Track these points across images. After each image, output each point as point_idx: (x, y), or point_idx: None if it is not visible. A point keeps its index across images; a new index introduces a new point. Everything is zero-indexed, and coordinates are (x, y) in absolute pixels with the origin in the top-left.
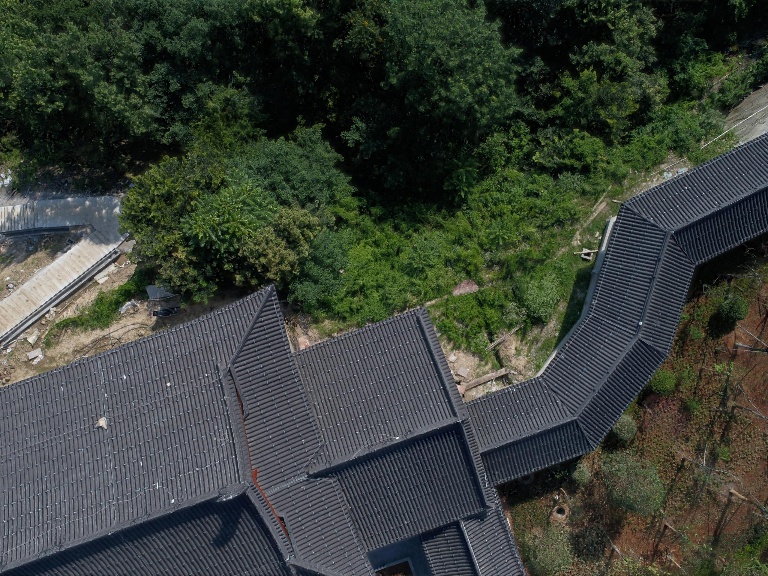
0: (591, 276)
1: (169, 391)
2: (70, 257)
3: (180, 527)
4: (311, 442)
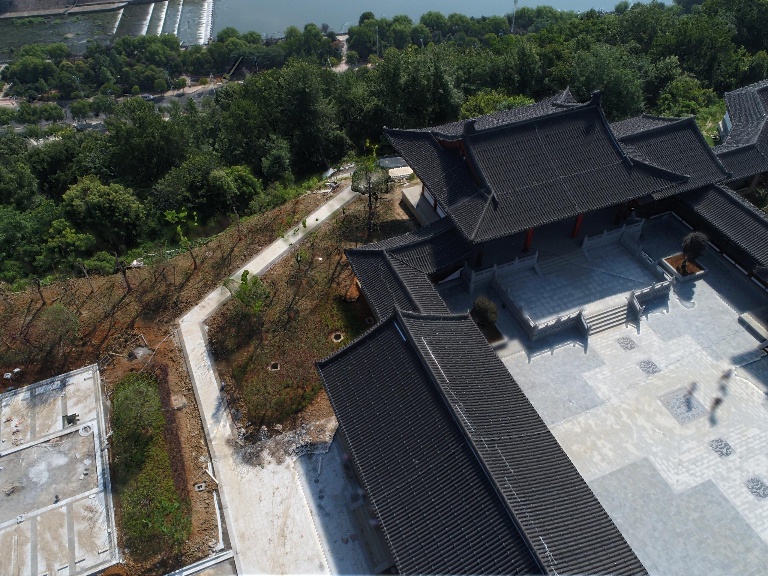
0: (722, 142)
1: None
2: (407, 168)
3: (564, 130)
4: None
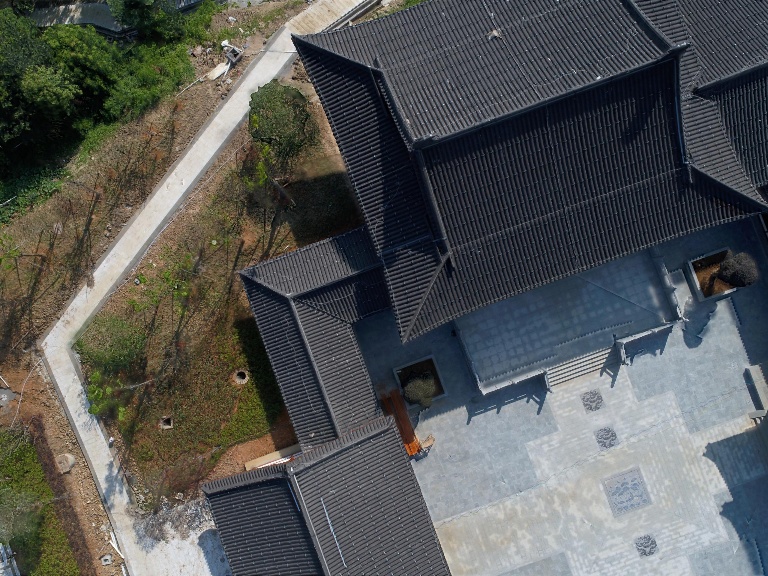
0: None
1: (559, 5)
2: None
3: (598, 112)
4: (691, 65)
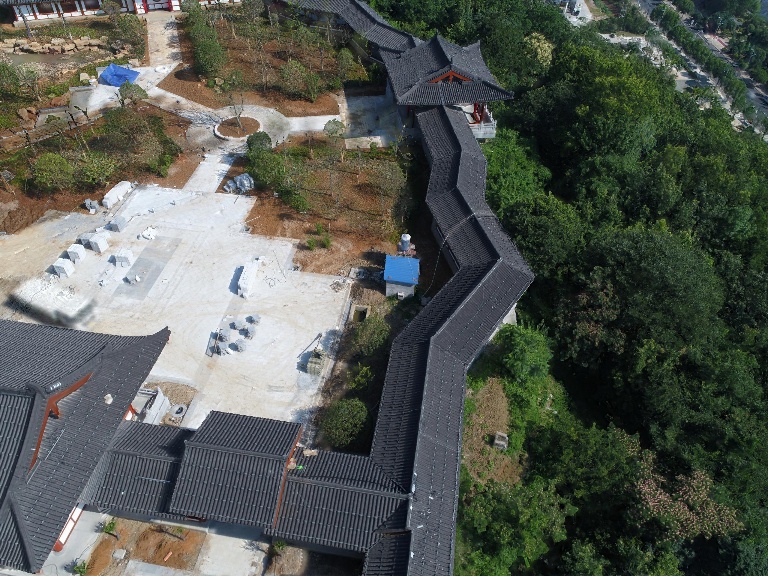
0: None
1: None
2: None
3: None
4: None
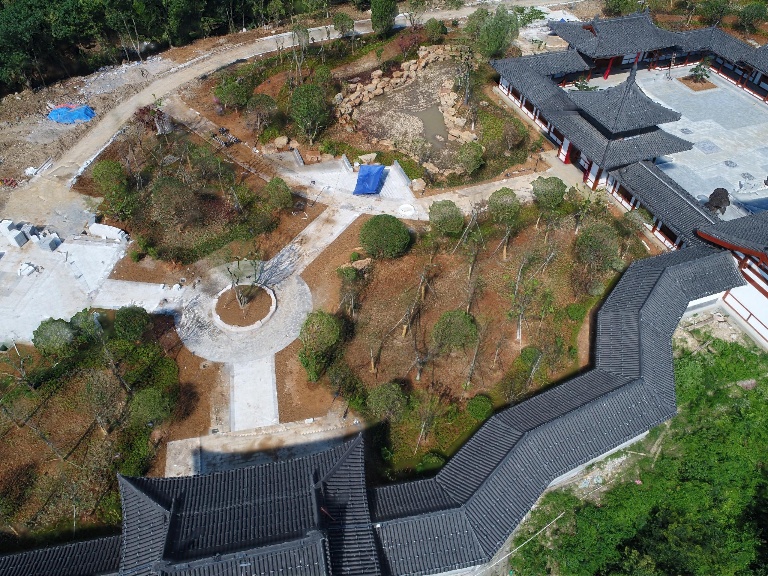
0: None
1: None
2: None
3: None
4: None
